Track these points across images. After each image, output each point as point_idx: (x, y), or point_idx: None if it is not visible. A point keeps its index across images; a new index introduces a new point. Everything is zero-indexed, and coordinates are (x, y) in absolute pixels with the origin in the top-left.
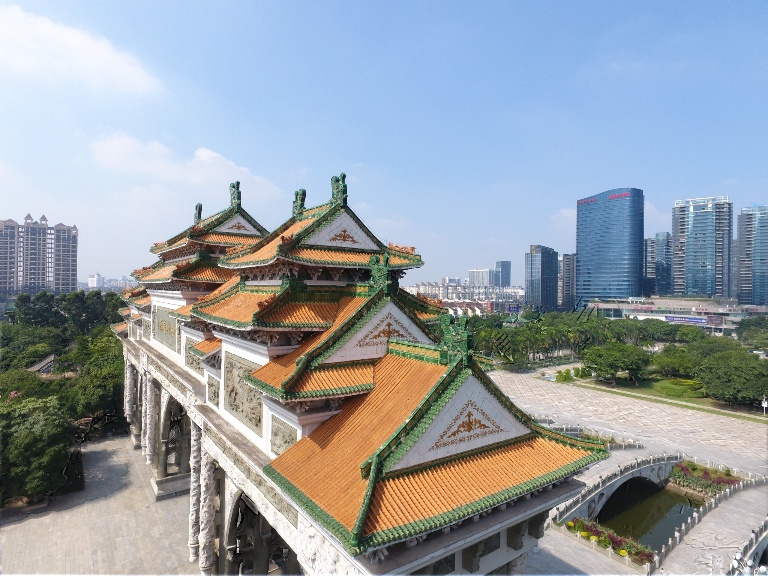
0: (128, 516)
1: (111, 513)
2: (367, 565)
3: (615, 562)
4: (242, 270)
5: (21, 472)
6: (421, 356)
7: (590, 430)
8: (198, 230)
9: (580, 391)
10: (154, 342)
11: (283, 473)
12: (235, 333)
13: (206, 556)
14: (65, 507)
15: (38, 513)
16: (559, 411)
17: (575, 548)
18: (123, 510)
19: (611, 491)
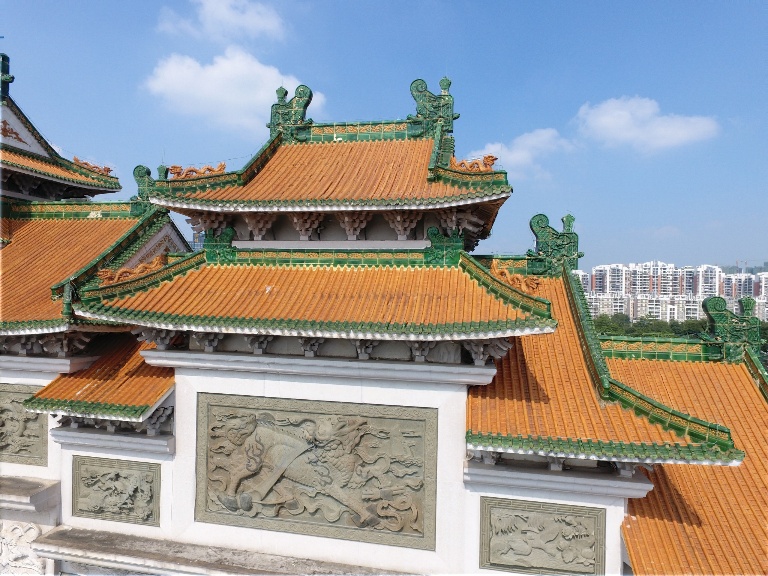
0: None
1: None
2: None
3: None
4: (249, 217)
5: None
6: (663, 354)
7: None
8: None
9: None
10: None
11: None
12: (265, 350)
13: None
14: None
15: None
16: None
17: None
18: None
19: None
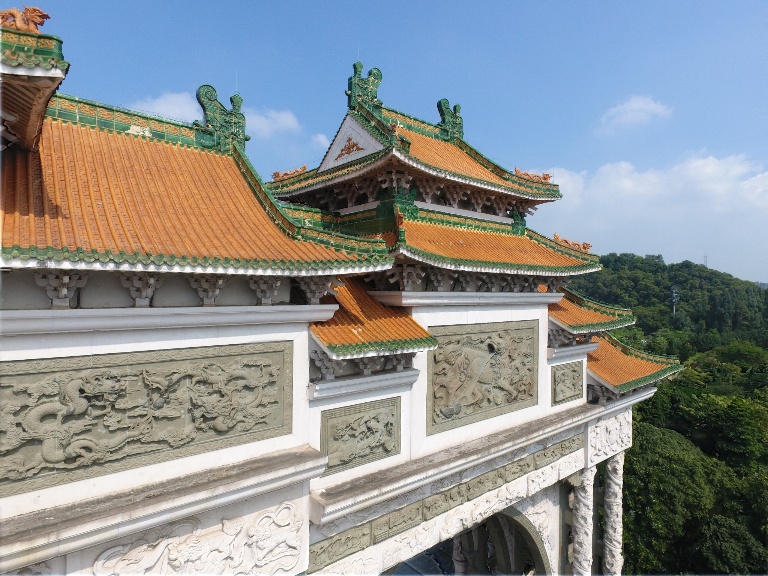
0: None
1: None
2: (653, 388)
3: None
4: (439, 183)
5: None
6: None
7: None
8: None
9: None
10: None
11: (624, 382)
12: None
13: None
14: None
15: None
16: None
17: None
18: None
19: None
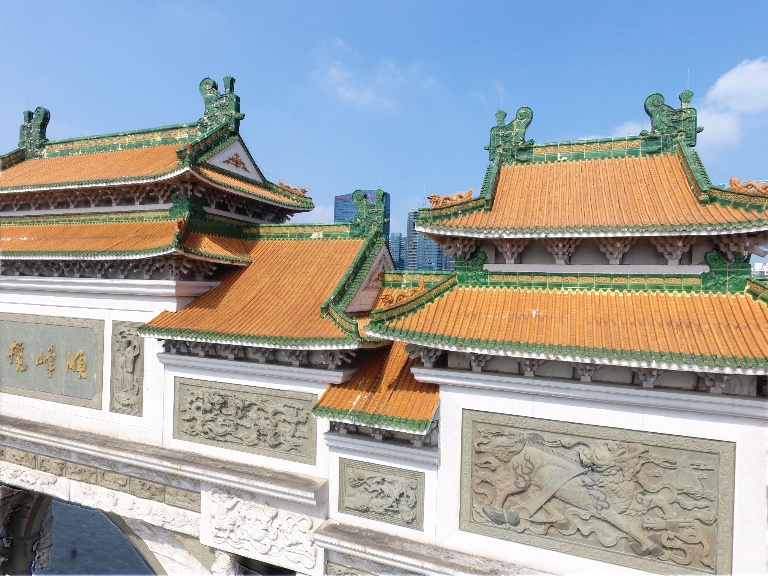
0: None
1: None
2: None
3: None
4: (508, 242)
5: None
6: None
7: None
8: None
9: None
10: None
11: None
12: (534, 372)
13: None
14: None
15: None
16: None
17: None
18: None
19: None
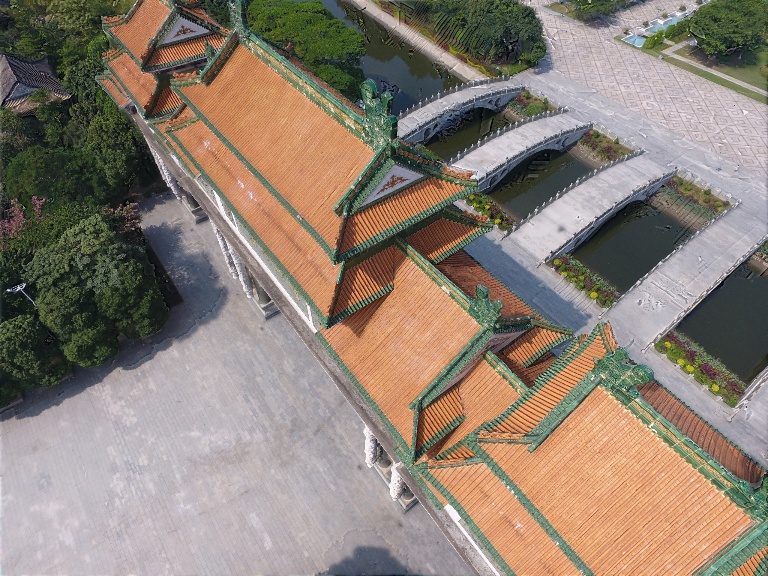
0: (250, 344)
1: (231, 340)
2: None
3: (706, 396)
4: None
5: (127, 325)
6: None
7: (686, 173)
8: (340, 232)
9: (671, 74)
10: (234, 227)
11: None
12: None
13: (398, 495)
14: (181, 331)
15: (160, 342)
16: (648, 125)
17: (671, 378)
18: (240, 335)
19: (708, 294)
